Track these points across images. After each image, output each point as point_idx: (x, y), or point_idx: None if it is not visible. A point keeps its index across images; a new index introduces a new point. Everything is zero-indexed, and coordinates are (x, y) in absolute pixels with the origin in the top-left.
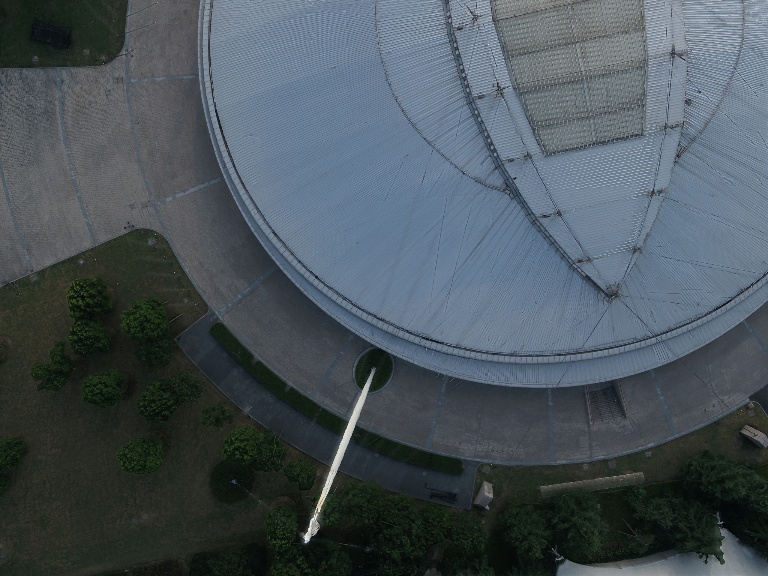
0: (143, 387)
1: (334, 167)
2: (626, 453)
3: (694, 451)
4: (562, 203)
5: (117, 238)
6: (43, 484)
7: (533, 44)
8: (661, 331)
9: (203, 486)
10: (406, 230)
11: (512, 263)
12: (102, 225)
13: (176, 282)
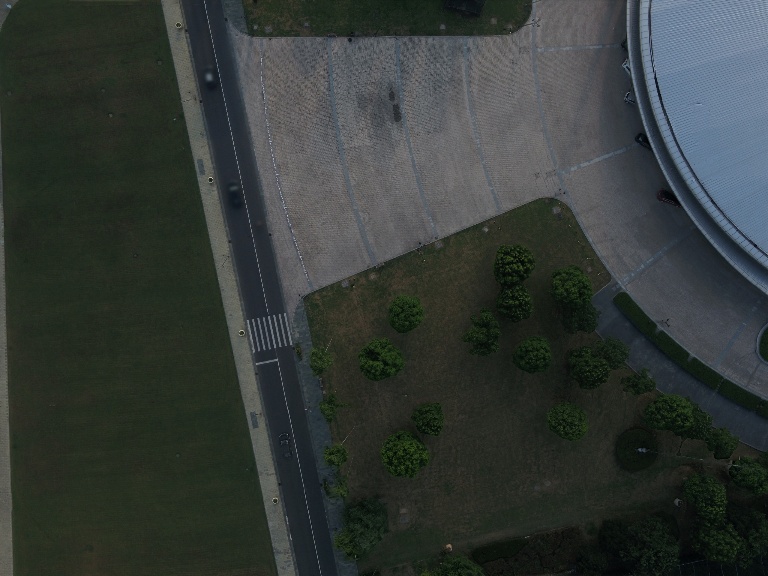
0: None
1: None
2: None
3: None
4: None
5: (521, 207)
6: (449, 450)
7: None
8: None
9: (607, 454)
10: None
11: None
12: (507, 193)
13: (580, 251)
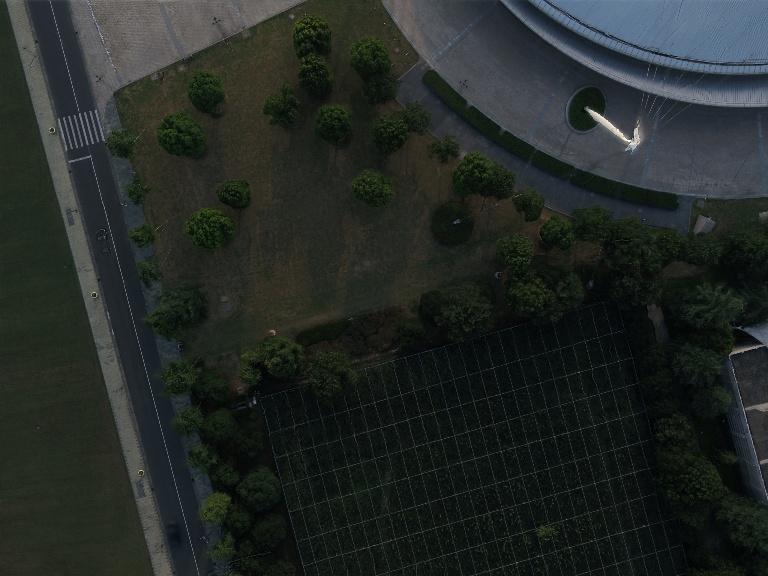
0: (360, 136)
1: None
2: None
3: None
4: None
5: None
6: (266, 235)
7: None
8: None
9: (424, 231)
10: None
11: None
12: None
13: (386, 32)
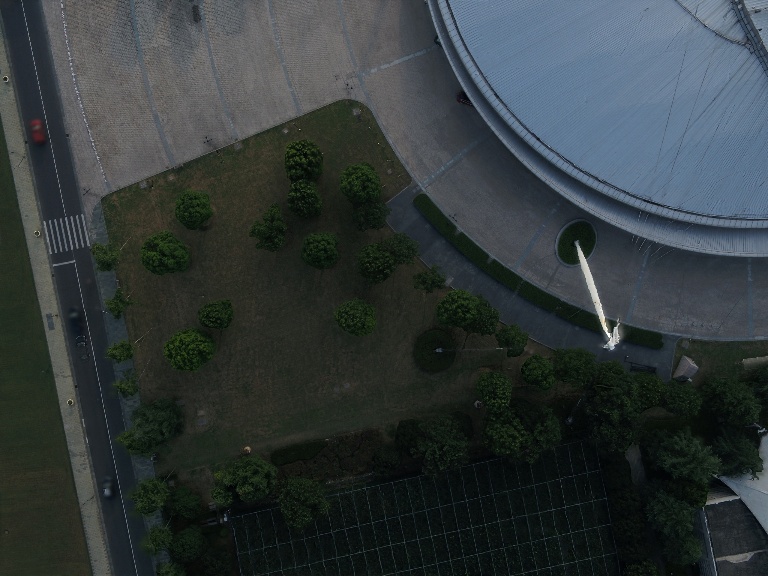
0: (347, 256)
1: (569, 23)
2: None
3: None
4: None
5: (321, 108)
6: (247, 351)
7: None
8: None
9: (405, 356)
10: (640, 86)
11: (745, 120)
12: (307, 95)
13: (380, 153)
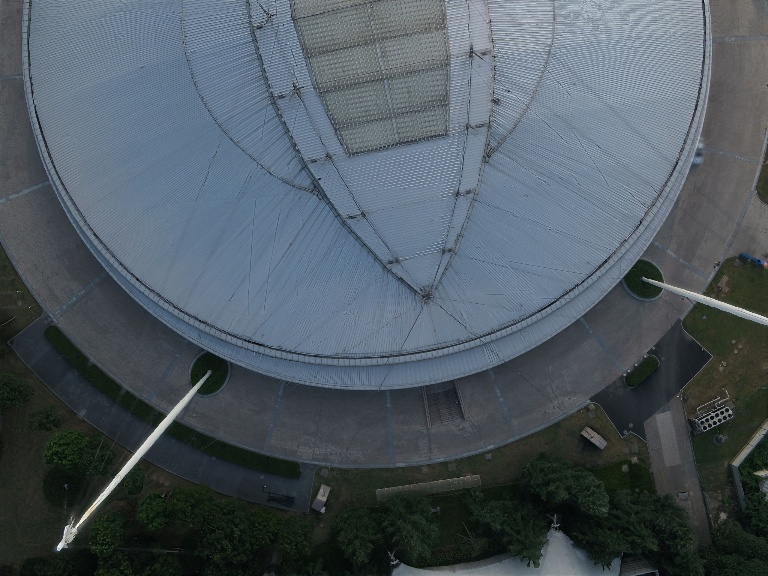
0: None
1: (146, 168)
2: (466, 455)
3: (533, 453)
4: (368, 204)
5: None
6: None
7: (332, 43)
8: (485, 333)
9: (37, 491)
10: (218, 231)
11: (325, 265)
12: None
13: (10, 284)
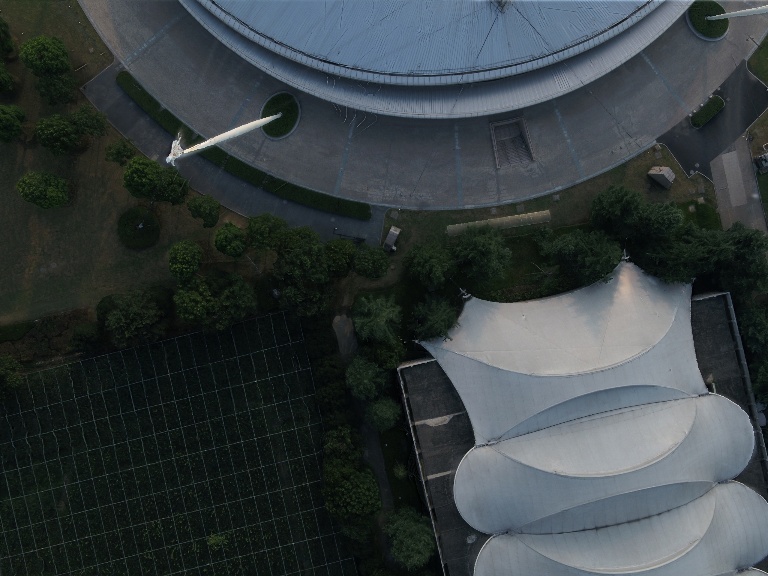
0: None
1: None
2: (534, 197)
3: None
4: None
5: None
6: None
7: None
8: (558, 49)
9: (111, 234)
10: None
11: None
12: None
13: (81, 32)
